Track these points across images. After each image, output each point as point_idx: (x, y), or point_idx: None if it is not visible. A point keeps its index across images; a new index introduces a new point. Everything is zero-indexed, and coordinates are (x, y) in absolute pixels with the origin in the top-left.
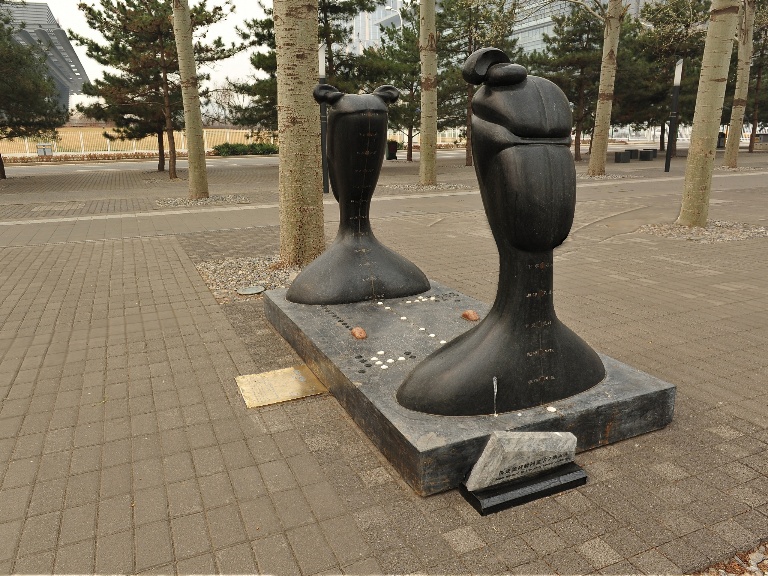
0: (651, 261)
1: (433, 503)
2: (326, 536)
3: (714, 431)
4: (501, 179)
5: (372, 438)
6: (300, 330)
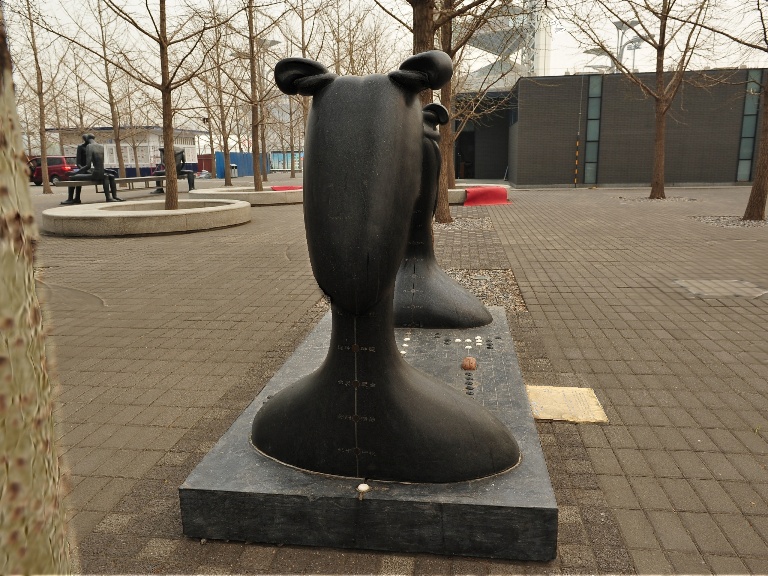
0: None
1: None
2: None
3: None
4: None
5: None
6: None
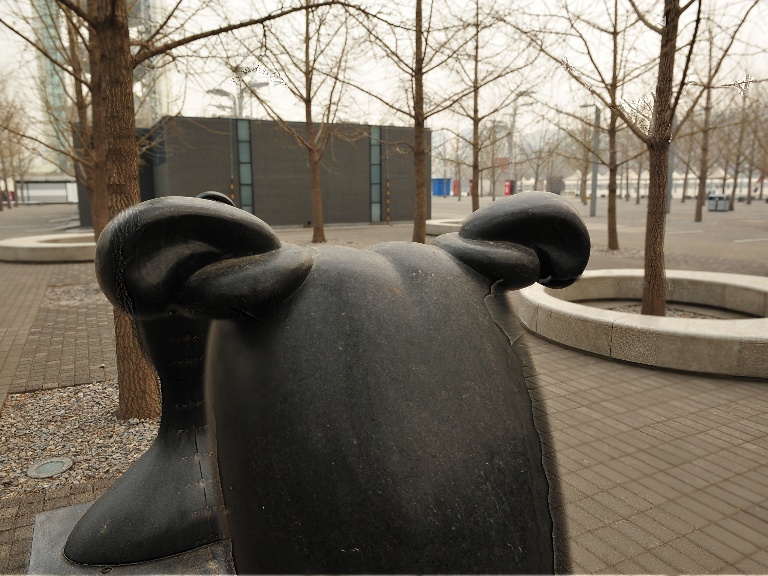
0: None
1: None
2: None
3: (7, 551)
4: None
5: None
6: None
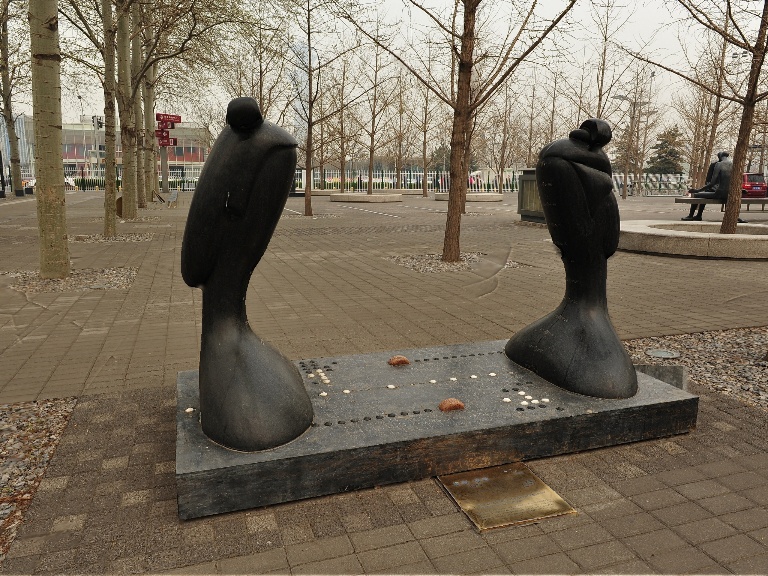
0: (166, 308)
1: (693, 430)
2: (764, 467)
3: None
4: (614, 211)
5: (626, 440)
6: (421, 439)
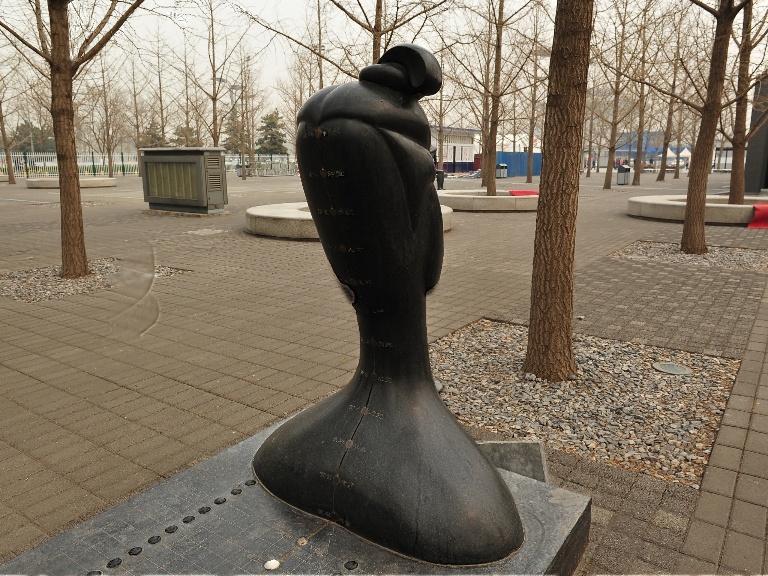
0: None
1: None
2: None
3: None
4: (440, 218)
5: None
6: None
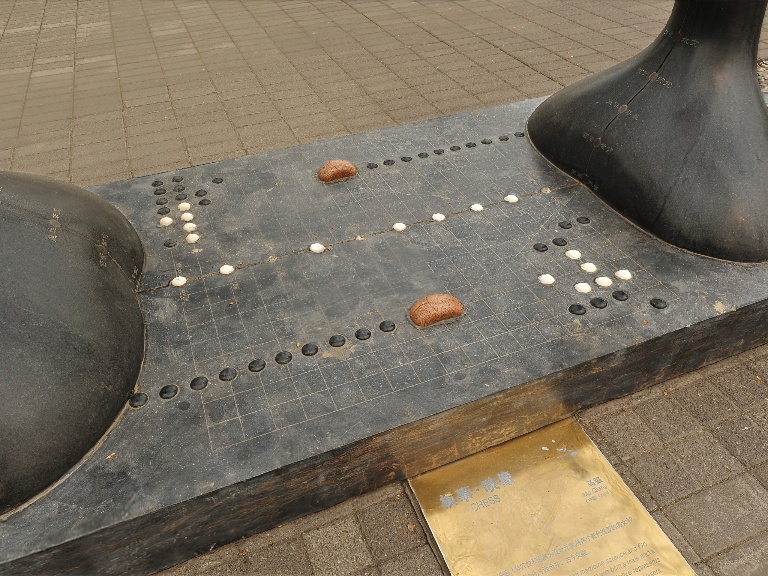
0: None
1: None
2: None
3: None
4: None
5: (767, 339)
6: (369, 439)
